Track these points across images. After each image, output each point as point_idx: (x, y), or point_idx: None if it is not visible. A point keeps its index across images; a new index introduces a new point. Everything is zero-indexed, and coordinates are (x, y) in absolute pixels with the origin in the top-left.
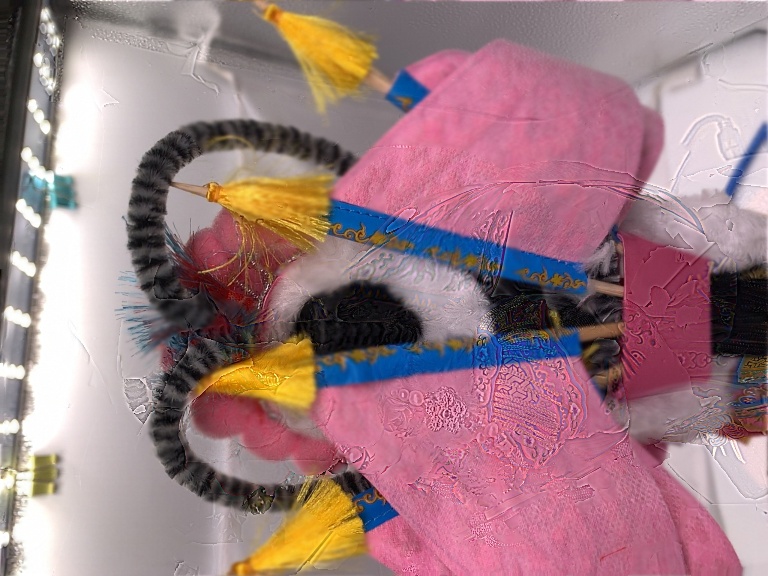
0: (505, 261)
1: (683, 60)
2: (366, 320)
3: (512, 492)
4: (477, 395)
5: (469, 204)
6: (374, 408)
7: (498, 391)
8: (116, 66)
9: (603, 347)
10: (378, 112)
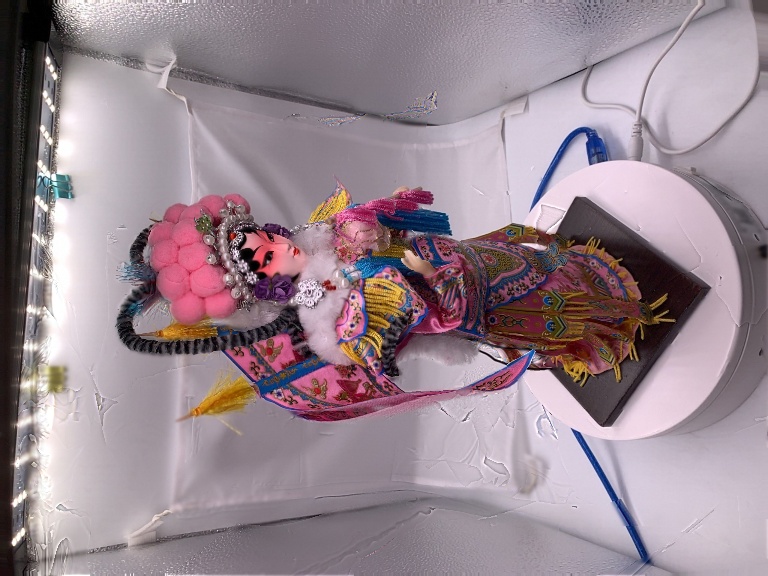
0: None
1: None
2: None
3: None
4: None
5: None
6: None
7: None
8: None
9: None
10: None
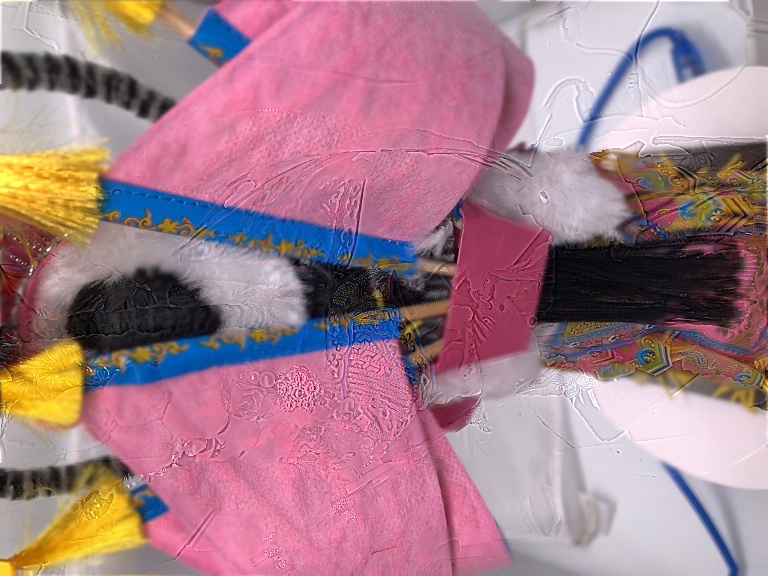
0: (360, 231)
1: (543, 23)
2: (210, 301)
3: (372, 464)
4: (331, 372)
5: (314, 174)
6: (215, 396)
7: (352, 366)
8: None
9: (459, 313)
10: (241, 73)
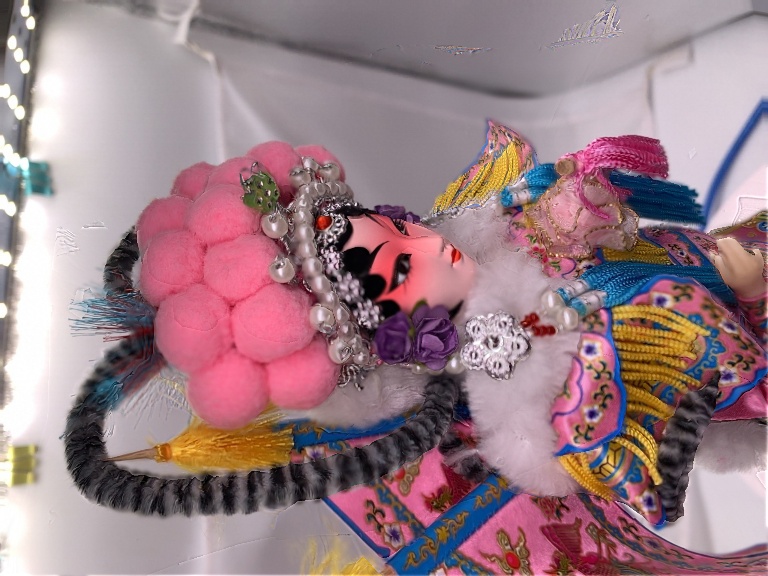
0: None
1: None
2: None
3: None
4: None
5: None
6: None
7: None
8: None
9: None
10: None
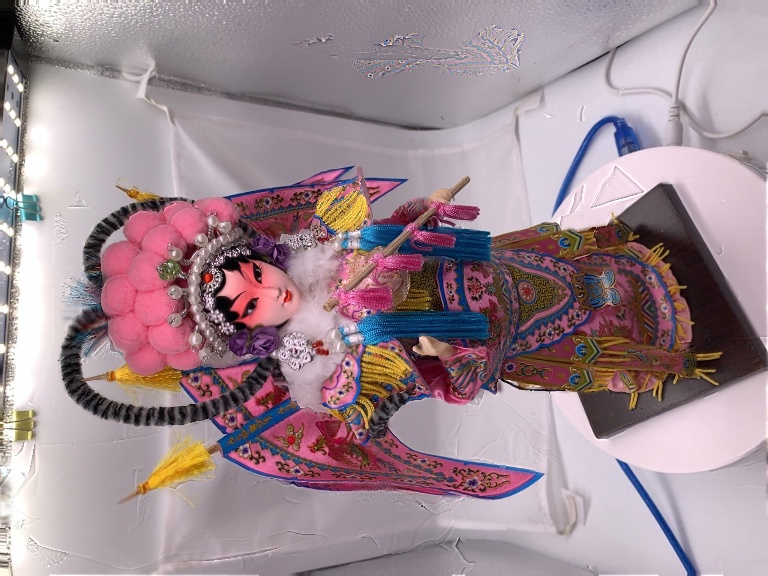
0: None
1: None
2: None
3: None
4: None
5: None
6: None
7: None
8: (71, 572)
9: None
10: None
